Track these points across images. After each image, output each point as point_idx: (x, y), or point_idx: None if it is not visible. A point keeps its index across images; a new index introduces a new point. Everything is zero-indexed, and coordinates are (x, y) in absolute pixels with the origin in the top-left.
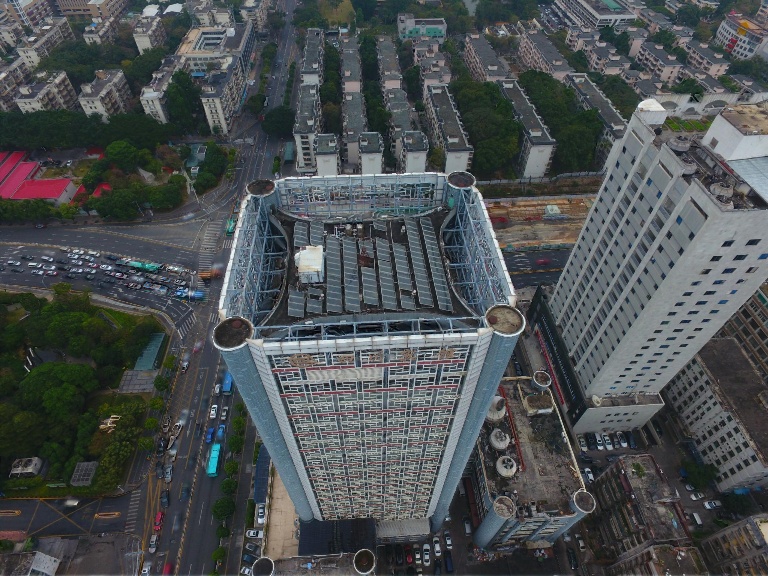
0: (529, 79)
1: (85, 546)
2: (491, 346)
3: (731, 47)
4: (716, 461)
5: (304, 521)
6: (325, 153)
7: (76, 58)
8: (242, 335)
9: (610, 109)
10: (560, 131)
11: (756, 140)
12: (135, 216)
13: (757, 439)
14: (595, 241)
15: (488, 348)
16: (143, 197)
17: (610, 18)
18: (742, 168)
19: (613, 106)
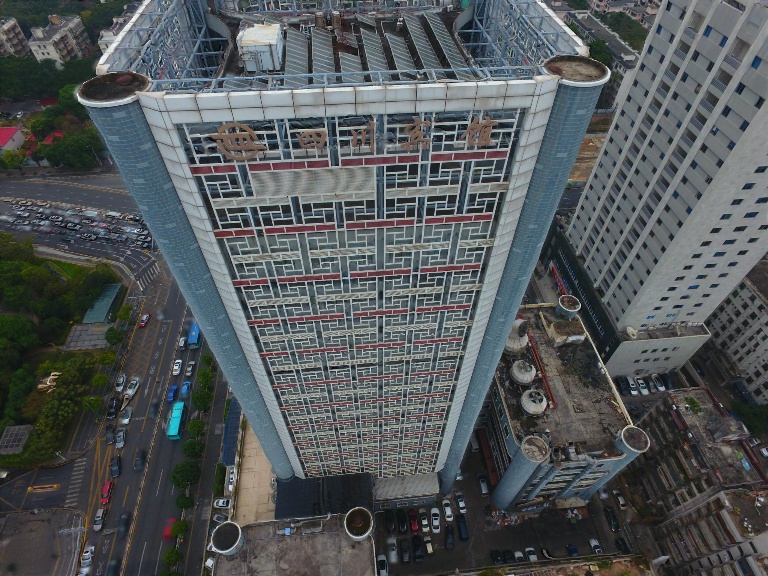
0: None
1: (14, 525)
2: (551, 121)
3: None
4: None
5: (282, 479)
6: None
7: (30, 9)
8: (131, 92)
9: (618, 42)
10: None
11: None
12: (91, 163)
13: None
14: (628, 137)
15: (545, 128)
16: (100, 144)
17: None
18: None
19: (621, 39)
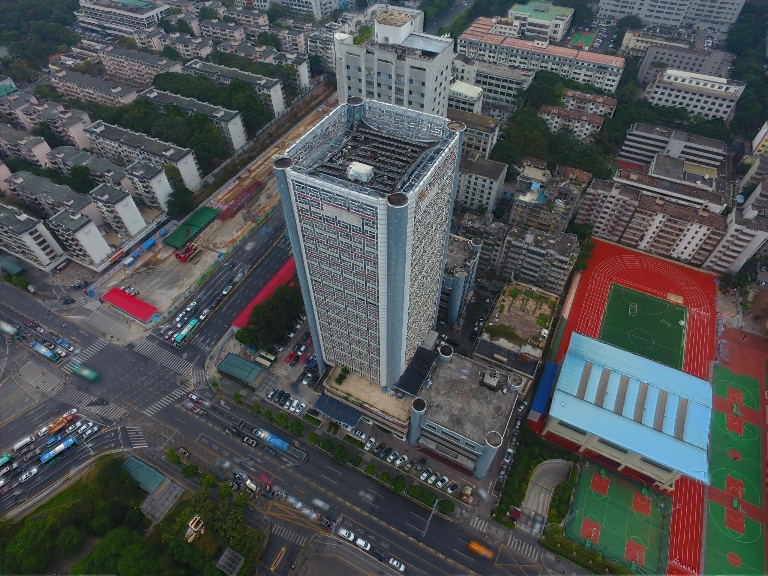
0: (165, 82)
1: None
2: (459, 142)
3: (251, 4)
4: (479, 202)
5: (398, 383)
6: (82, 226)
7: None
8: (401, 198)
9: (243, 74)
10: (231, 104)
11: (405, 28)
12: None
13: (485, 175)
14: None
15: None
16: None
17: (151, 14)
18: (409, 44)
19: (242, 71)
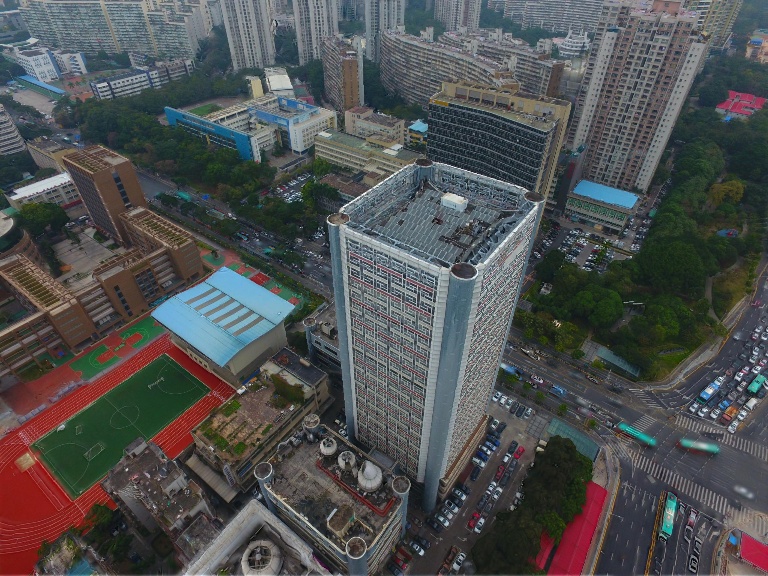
0: None
1: None
2: None
3: None
4: None
5: None
6: None
7: None
8: None
9: None
10: None
11: None
12: None
13: None
14: None
15: None
16: None
17: None
18: None
19: None
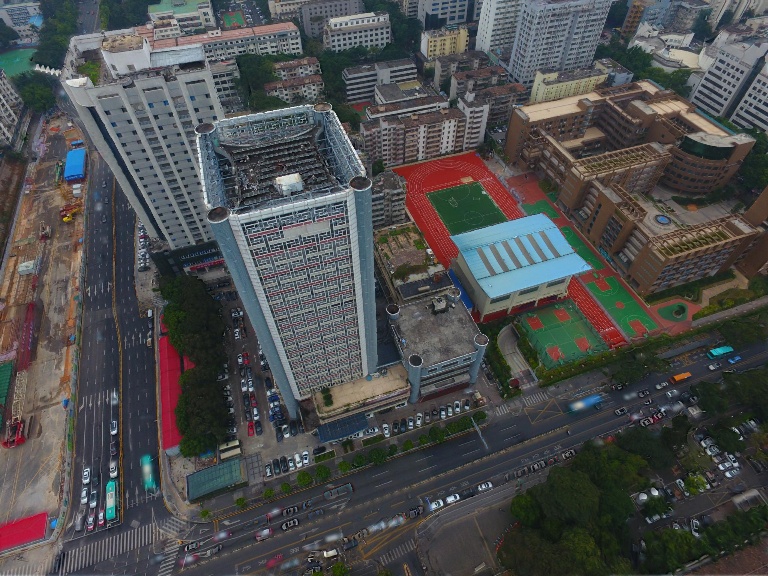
0: None
1: None
2: None
3: None
4: None
5: (377, 363)
6: None
7: None
8: (360, 181)
9: None
10: None
11: (145, 48)
12: None
13: None
14: (157, 174)
15: None
16: None
17: None
18: (160, 64)
19: None
